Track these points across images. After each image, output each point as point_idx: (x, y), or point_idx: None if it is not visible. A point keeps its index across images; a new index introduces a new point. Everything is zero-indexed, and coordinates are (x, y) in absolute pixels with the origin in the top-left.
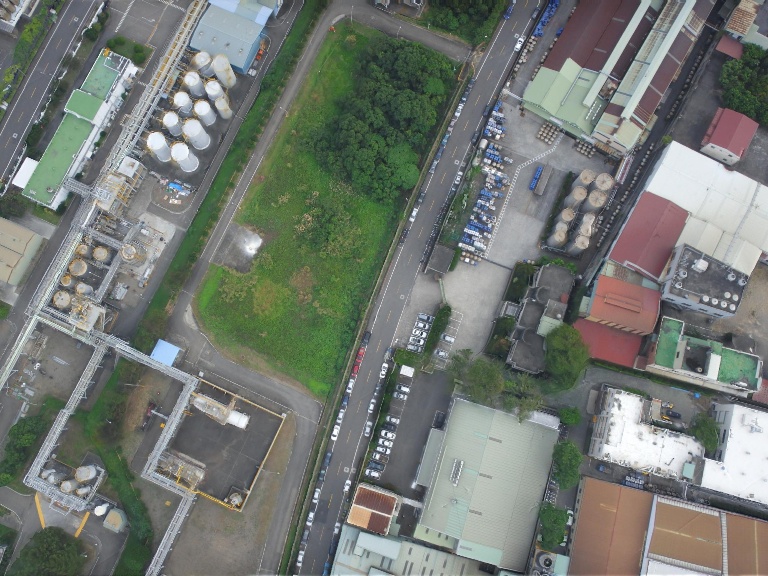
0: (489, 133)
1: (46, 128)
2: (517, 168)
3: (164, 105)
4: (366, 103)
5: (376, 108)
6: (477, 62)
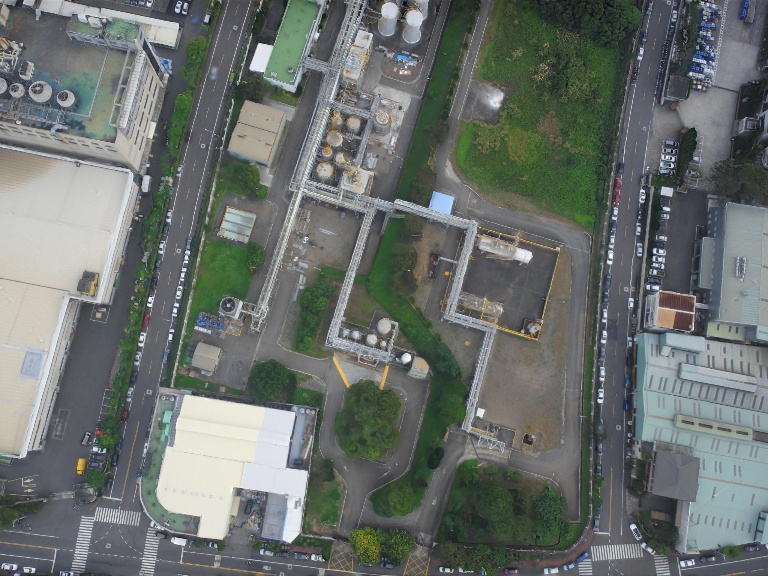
0: None
1: (266, 17)
2: (725, 2)
3: None
4: None
5: None
6: None
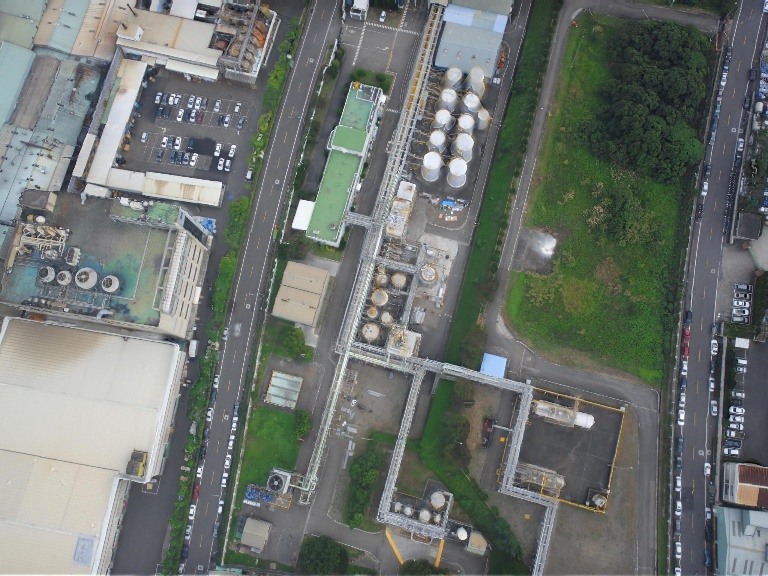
0: (763, 96)
1: (307, 169)
2: None
3: (419, 127)
4: (638, 87)
5: (649, 90)
6: (729, 30)
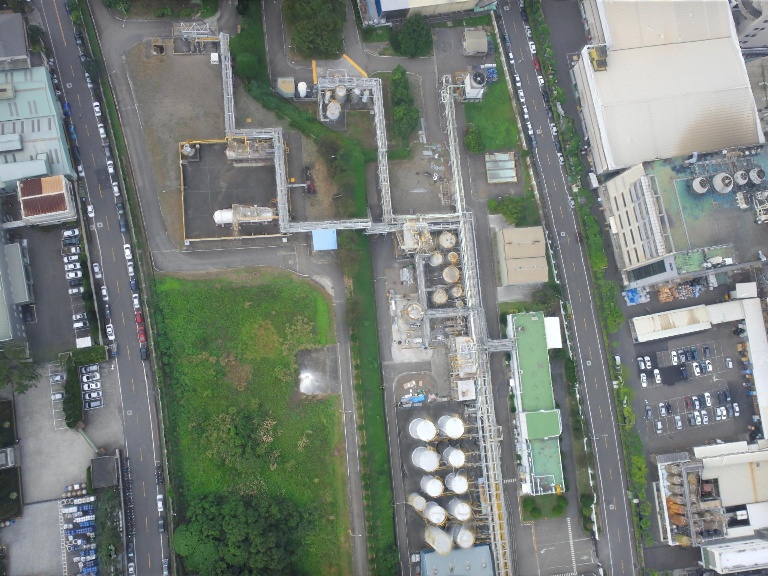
0: None
1: (567, 385)
2: None
3: (477, 471)
4: None
5: None
6: None
